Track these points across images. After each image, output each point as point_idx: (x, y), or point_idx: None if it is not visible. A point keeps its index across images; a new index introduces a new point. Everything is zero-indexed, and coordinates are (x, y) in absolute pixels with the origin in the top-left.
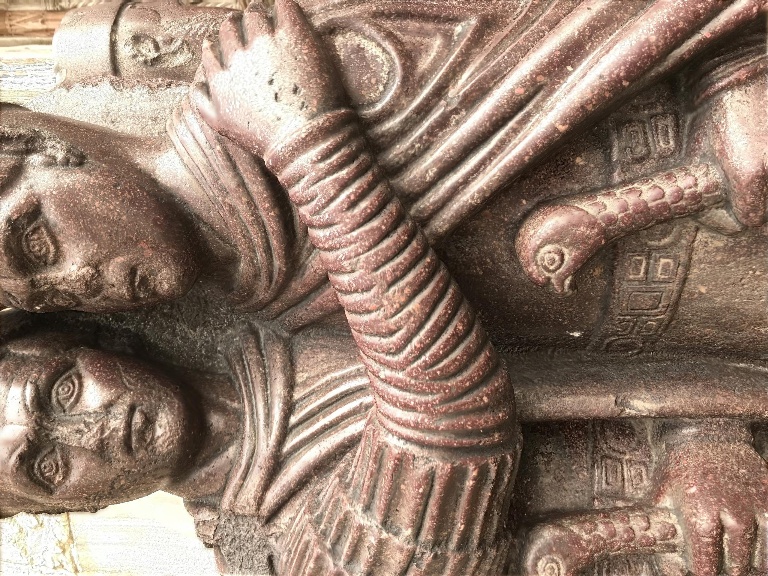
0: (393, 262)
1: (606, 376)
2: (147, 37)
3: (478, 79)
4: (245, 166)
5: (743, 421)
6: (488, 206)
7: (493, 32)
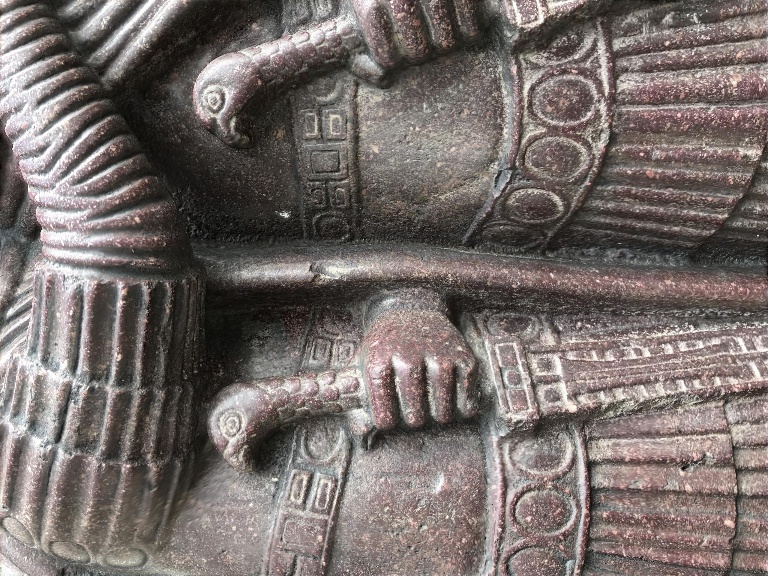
0: (45, 82)
1: (310, 250)
2: None
3: None
4: None
5: (439, 293)
6: (176, 69)
7: None
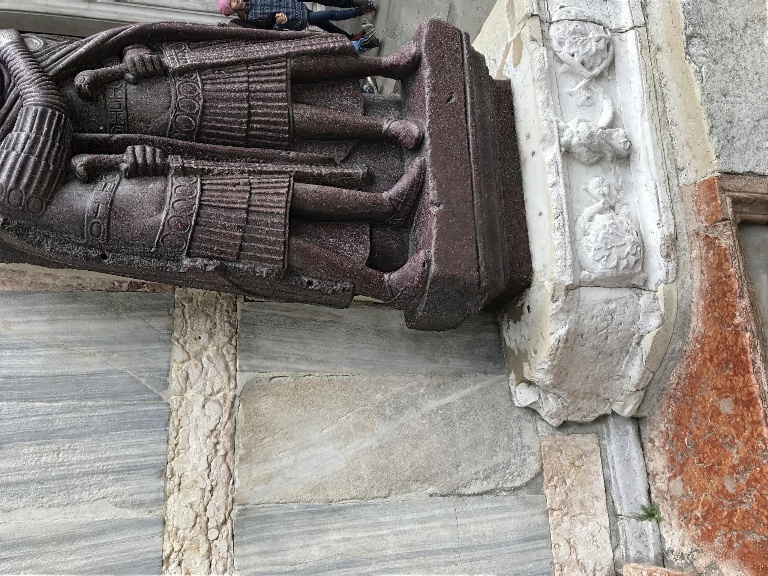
0: None
1: None
2: None
3: None
4: None
5: None
6: (68, 79)
7: None
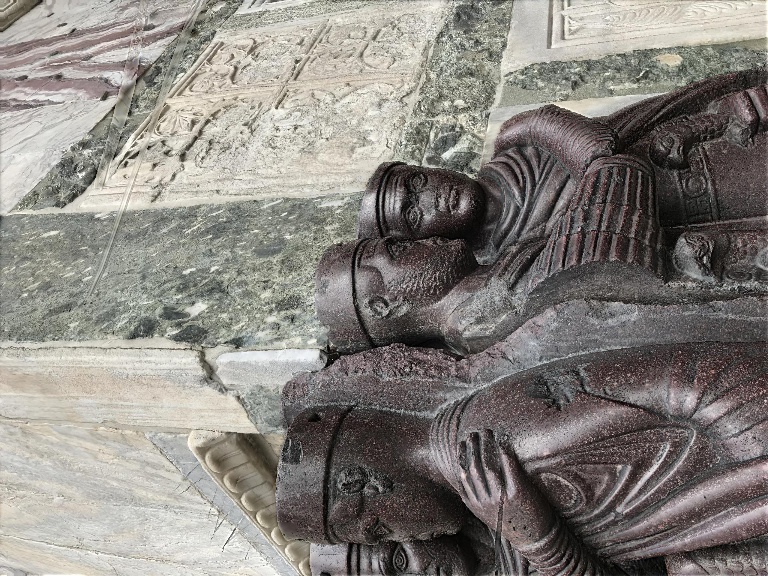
0: None
1: None
2: (378, 299)
3: (634, 508)
4: None
5: None
6: None
7: (643, 471)
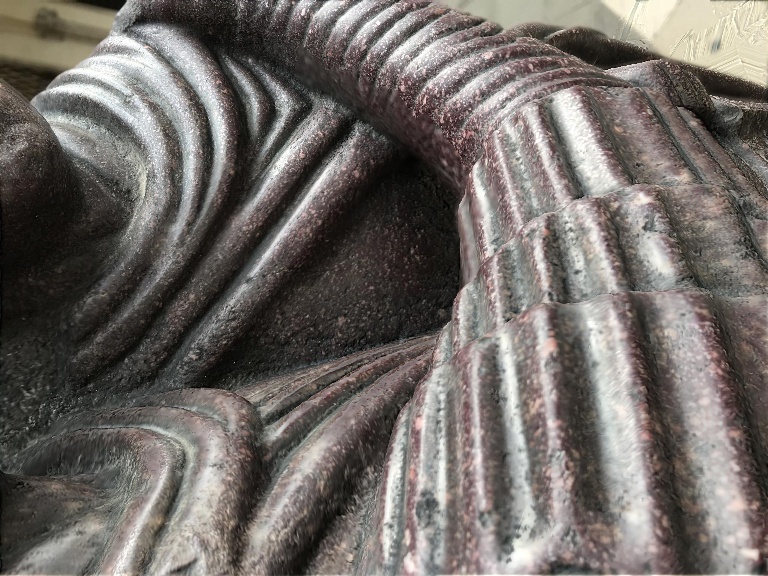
0: None
1: None
2: None
3: None
4: (190, 49)
5: None
6: None
7: None
